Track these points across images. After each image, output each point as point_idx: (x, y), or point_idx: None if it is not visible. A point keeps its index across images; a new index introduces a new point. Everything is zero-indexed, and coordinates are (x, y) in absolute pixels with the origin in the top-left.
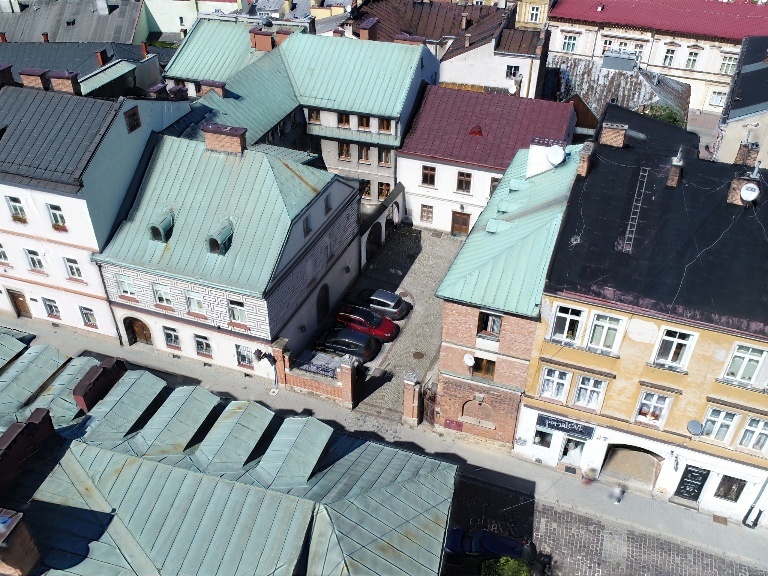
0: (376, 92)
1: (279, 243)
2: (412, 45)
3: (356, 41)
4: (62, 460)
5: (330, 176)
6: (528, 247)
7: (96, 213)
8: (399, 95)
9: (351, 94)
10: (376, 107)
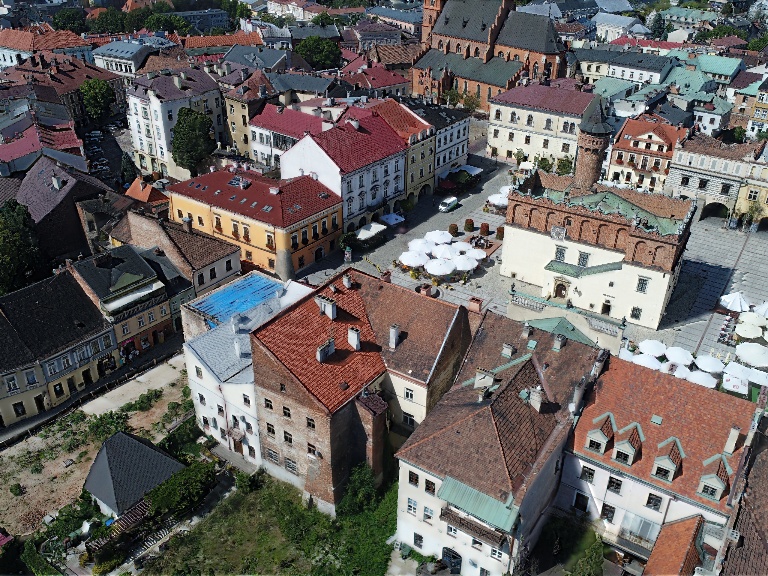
0: (726, 69)
1: (701, 86)
2: (739, 59)
3: (722, 57)
4: None
5: (713, 79)
6: (757, 85)
7: None
8: (732, 71)
9: (718, 69)
10: (725, 73)
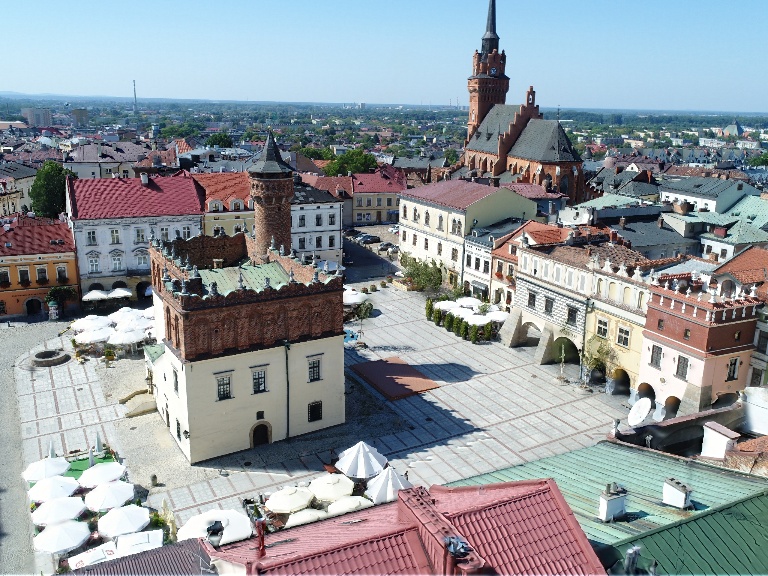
0: None
1: None
2: None
3: None
4: (693, 212)
5: None
6: None
7: (718, 207)
8: None
9: None
10: None
